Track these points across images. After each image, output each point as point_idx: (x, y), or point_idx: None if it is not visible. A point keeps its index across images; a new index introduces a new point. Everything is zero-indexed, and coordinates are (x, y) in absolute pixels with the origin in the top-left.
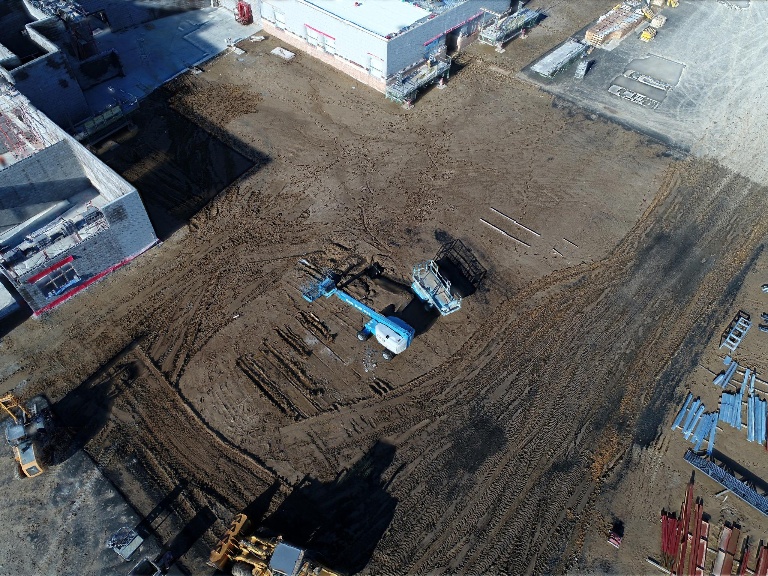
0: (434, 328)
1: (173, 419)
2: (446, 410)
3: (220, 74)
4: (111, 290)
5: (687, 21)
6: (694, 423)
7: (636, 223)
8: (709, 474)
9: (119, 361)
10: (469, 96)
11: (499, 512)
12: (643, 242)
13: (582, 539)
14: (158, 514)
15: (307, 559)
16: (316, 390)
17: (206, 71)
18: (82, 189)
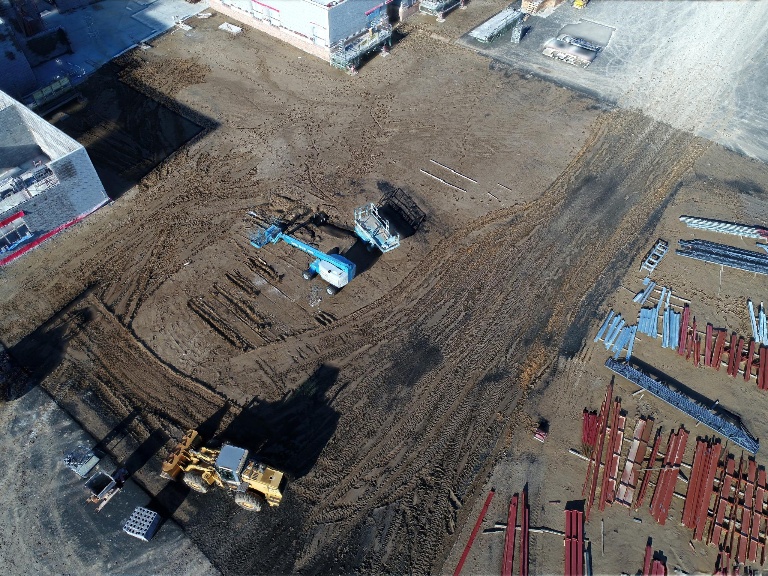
0: (376, 266)
1: (127, 356)
2: (387, 335)
3: (168, 49)
4: (64, 245)
5: None
6: (615, 335)
7: (566, 168)
8: (627, 377)
9: (73, 308)
10: (411, 62)
11: (435, 418)
12: (572, 184)
13: (511, 437)
14: (113, 437)
15: (252, 459)
16: (264, 324)
17: (154, 46)
18: (33, 156)
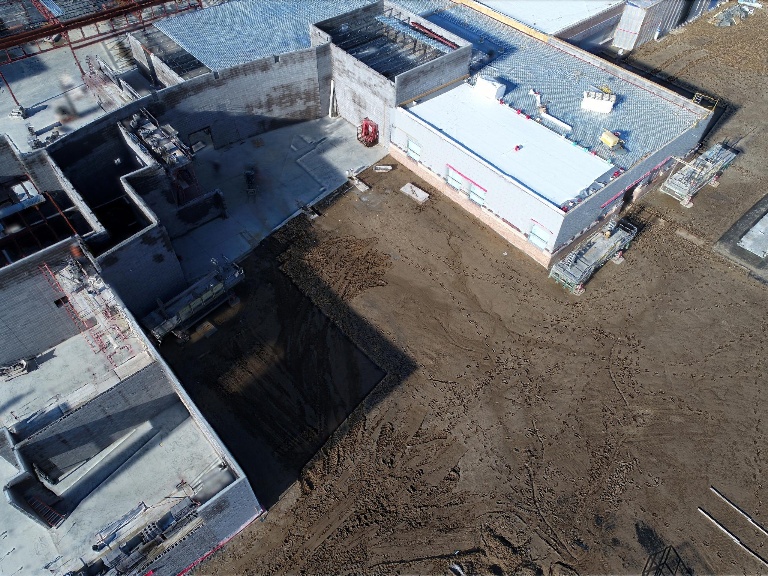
0: None
1: None
2: None
3: (339, 220)
4: None
5: None
6: None
7: None
8: None
9: None
10: (655, 278)
11: None
12: None
13: None
14: None
15: None
16: None
17: (323, 214)
18: (169, 405)
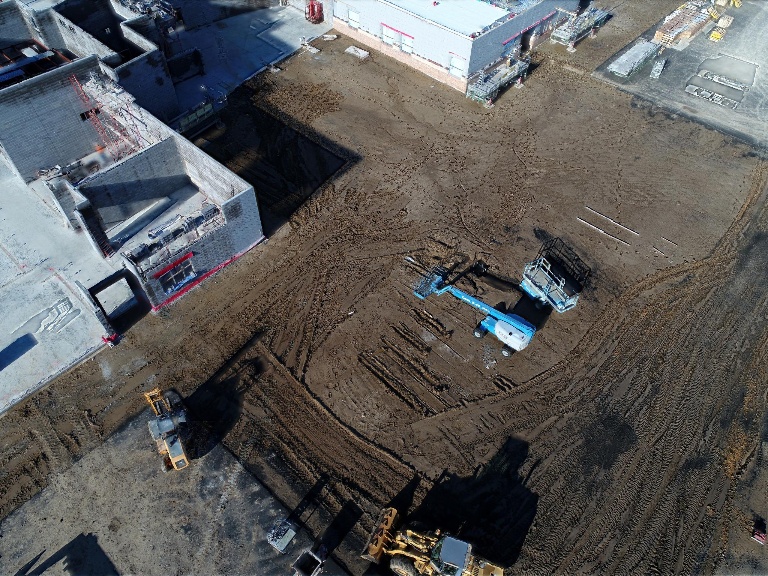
0: (547, 326)
1: (304, 414)
2: (572, 407)
3: (298, 72)
4: (224, 286)
5: (753, 21)
6: None
7: (732, 222)
8: None
9: (243, 356)
10: (547, 95)
11: (640, 508)
12: (742, 241)
13: (726, 535)
14: (305, 507)
15: (471, 552)
16: (441, 386)
17: (284, 69)
18: (181, 186)
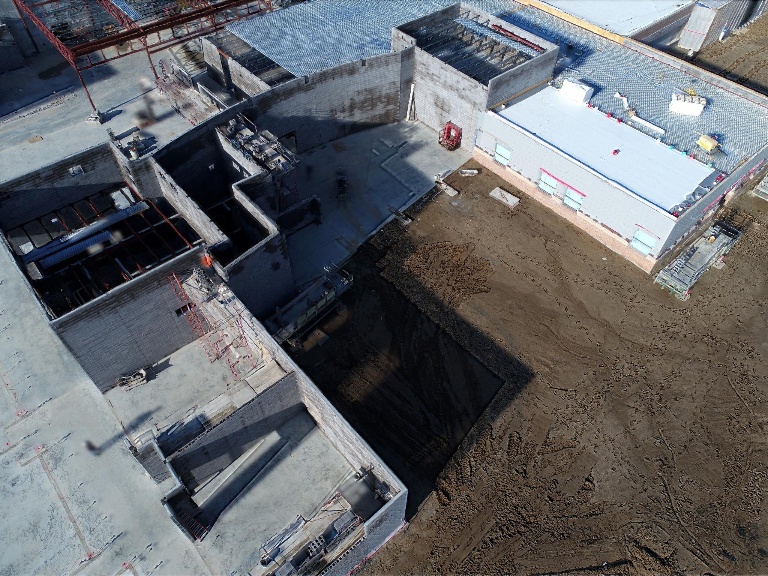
0: None
1: None
2: None
3: (433, 225)
4: None
5: None
6: None
7: None
8: None
9: None
10: (758, 282)
11: None
12: None
13: None
14: None
15: None
16: None
17: (415, 220)
18: (294, 415)
